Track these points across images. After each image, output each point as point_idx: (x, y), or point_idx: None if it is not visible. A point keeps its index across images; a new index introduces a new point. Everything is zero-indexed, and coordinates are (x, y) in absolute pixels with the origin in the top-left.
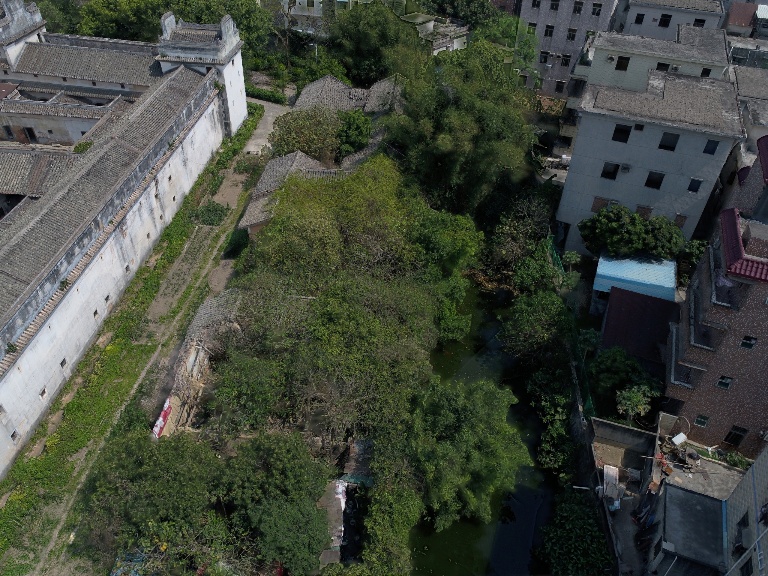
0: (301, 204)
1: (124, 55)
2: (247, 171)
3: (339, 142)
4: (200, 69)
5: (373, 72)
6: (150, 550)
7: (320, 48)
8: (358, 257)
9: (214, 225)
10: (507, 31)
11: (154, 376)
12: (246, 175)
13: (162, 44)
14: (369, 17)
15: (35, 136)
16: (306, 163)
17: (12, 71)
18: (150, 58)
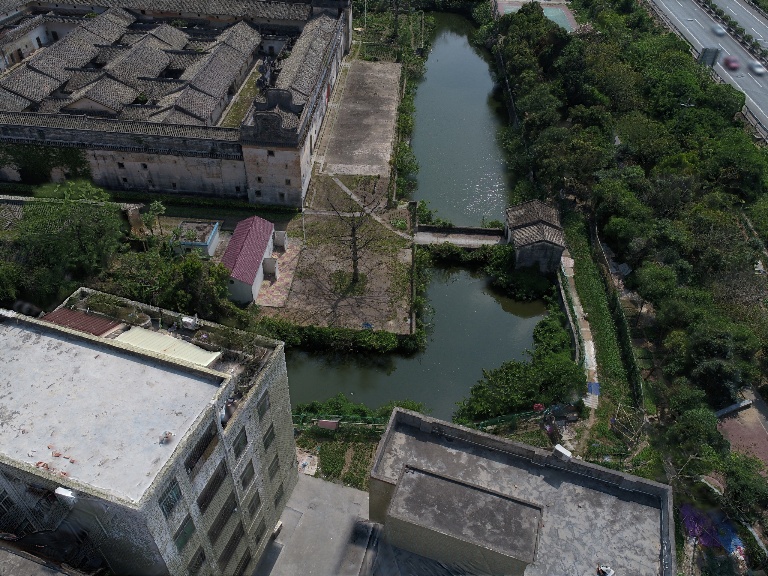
0: None
1: None
2: None
3: None
4: None
5: None
6: None
7: None
8: None
9: None
10: None
11: None
12: None
13: None
14: None
15: (22, 54)
16: None
17: None
18: None
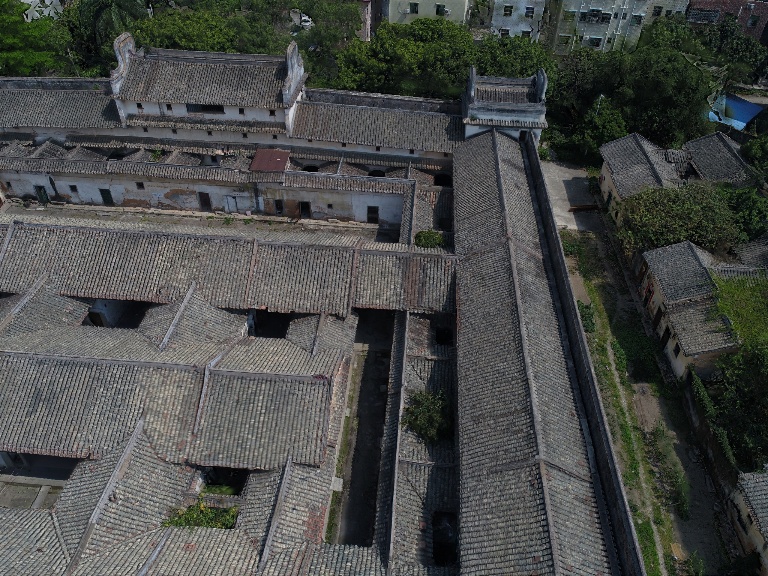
0: (759, 322)
1: (413, 115)
2: (571, 253)
3: (738, 230)
4: (512, 133)
5: (654, 124)
6: None
7: (604, 99)
8: None
9: (588, 332)
10: (762, 69)
11: (681, 575)
12: (573, 258)
13: (476, 106)
14: (664, 63)
15: (310, 211)
16: (704, 257)
17: (287, 136)
18: (444, 119)
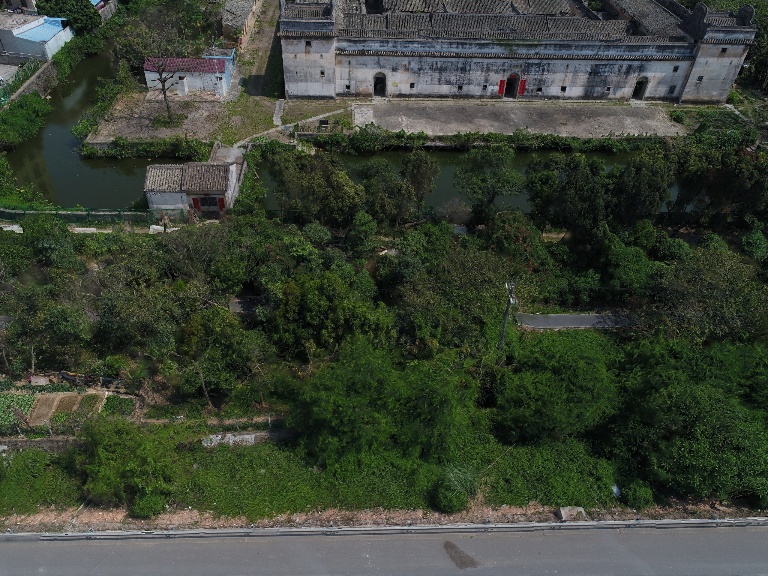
0: None
1: None
2: None
3: None
4: None
5: None
6: (765, 44)
7: None
8: (734, 1)
9: None
10: None
11: None
12: None
13: None
14: None
15: None
16: None
17: None
18: None
